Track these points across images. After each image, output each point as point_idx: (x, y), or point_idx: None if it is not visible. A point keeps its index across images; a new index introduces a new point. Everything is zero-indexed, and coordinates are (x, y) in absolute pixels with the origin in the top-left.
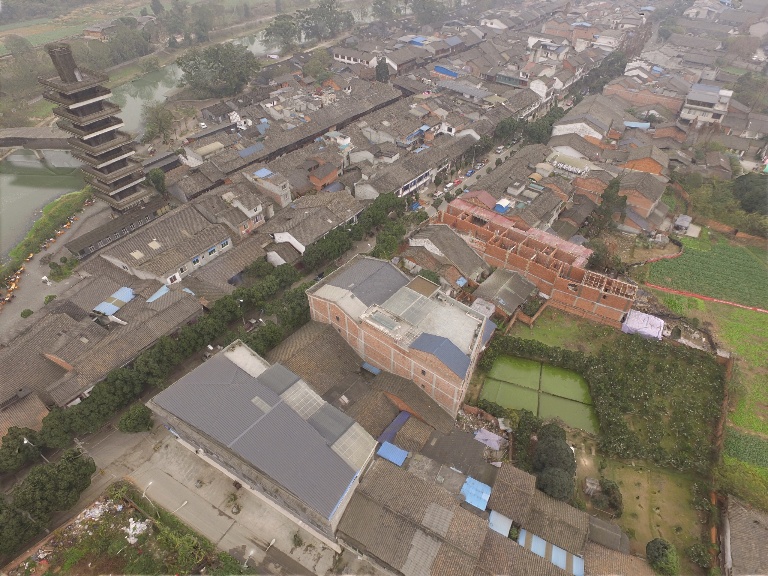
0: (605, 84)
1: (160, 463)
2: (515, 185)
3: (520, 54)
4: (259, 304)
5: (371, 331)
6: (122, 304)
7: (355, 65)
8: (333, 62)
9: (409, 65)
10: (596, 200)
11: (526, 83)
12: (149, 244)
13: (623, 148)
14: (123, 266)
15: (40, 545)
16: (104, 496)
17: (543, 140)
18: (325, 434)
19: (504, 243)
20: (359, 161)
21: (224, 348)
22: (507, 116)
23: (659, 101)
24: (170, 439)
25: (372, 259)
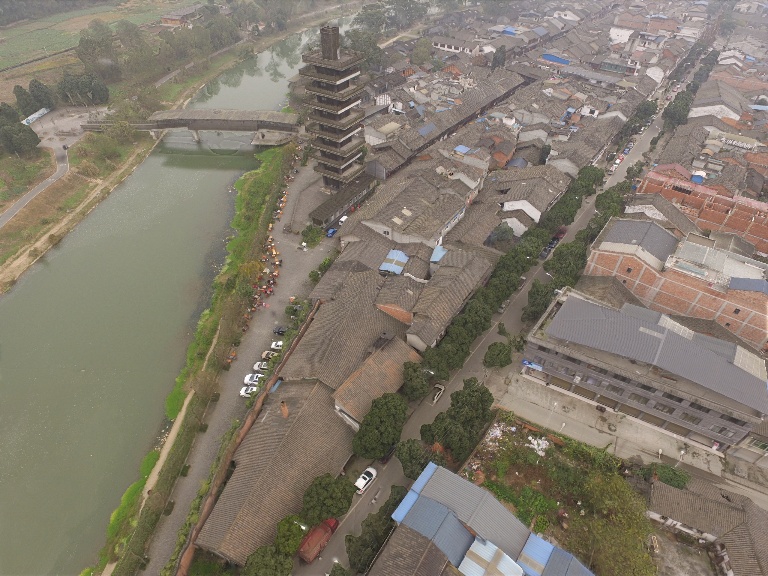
0: (709, 71)
1: (519, 394)
2: (702, 159)
3: (606, 44)
4: (534, 262)
5: (678, 278)
6: (403, 264)
7: (461, 53)
8: (436, 50)
9: (509, 53)
10: (765, 173)
11: (634, 70)
12: (402, 211)
13: (759, 128)
14: (385, 231)
15: (469, 459)
16: (496, 420)
17: (683, 121)
18: (719, 354)
19: (715, 209)
20: (529, 140)
21: (561, 293)
22: (641, 100)
23: (765, 87)
24: (515, 375)
25: (631, 220)
